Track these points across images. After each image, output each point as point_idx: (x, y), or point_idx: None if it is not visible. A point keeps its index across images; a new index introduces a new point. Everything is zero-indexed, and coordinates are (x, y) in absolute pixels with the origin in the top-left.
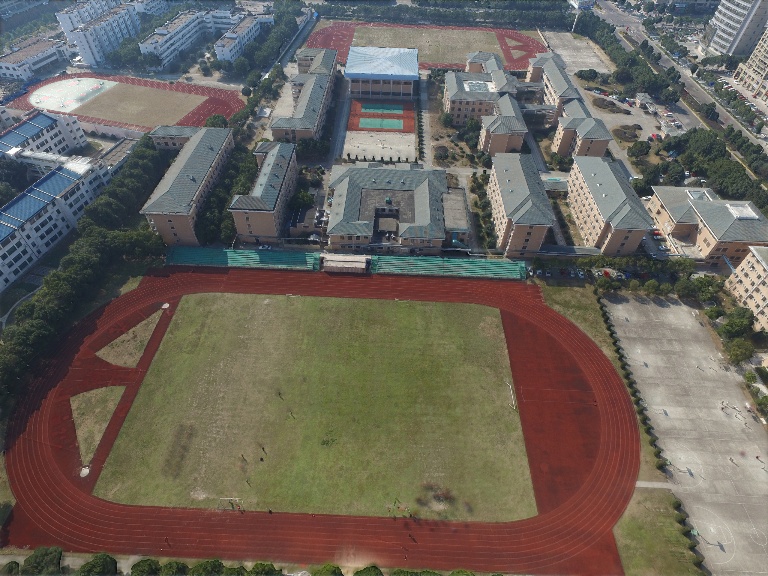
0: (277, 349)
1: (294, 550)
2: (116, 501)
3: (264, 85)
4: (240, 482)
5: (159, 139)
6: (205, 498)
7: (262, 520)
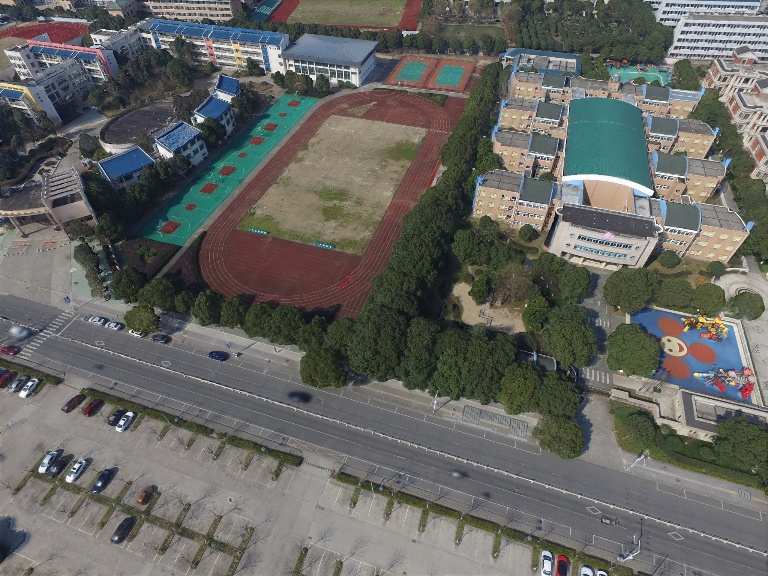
0: (333, 5)
1: (419, 1)
2: (399, 23)
3: (32, 6)
4: (394, 8)
5: (124, 10)
6: (400, 12)
7: (408, 5)
